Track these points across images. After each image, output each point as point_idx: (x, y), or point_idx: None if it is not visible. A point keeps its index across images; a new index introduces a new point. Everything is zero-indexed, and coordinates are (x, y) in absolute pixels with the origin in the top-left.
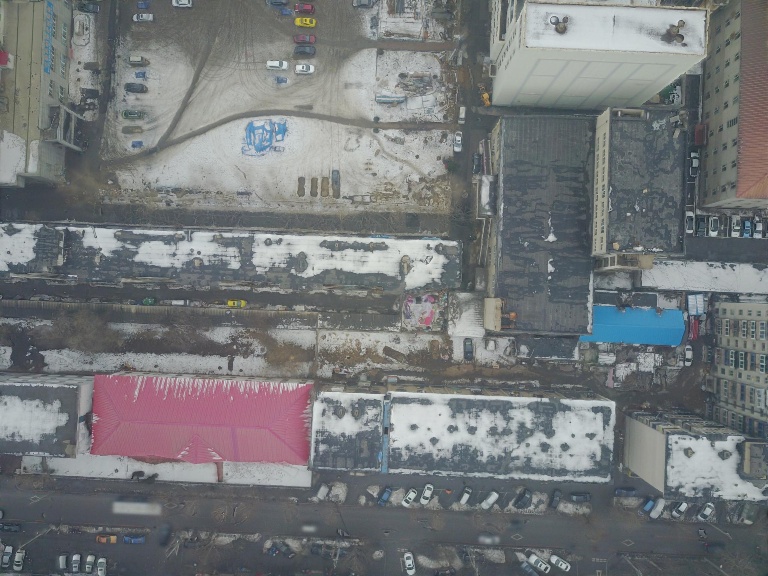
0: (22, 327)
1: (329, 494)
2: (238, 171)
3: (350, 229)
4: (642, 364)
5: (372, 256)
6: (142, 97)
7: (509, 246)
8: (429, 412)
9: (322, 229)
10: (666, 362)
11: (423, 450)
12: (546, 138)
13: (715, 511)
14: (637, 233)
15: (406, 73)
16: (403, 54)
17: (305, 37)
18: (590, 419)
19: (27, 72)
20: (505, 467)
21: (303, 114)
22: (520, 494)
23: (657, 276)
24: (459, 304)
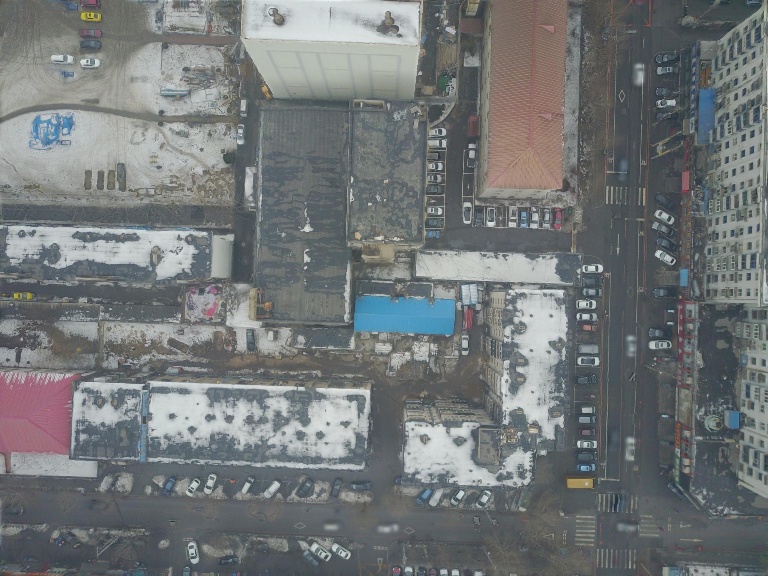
0: None
1: (115, 484)
2: (26, 165)
3: (136, 222)
4: (417, 353)
5: (123, 247)
6: None
7: (267, 237)
8: (187, 401)
9: (109, 222)
10: (445, 351)
11: (181, 439)
12: (302, 130)
13: (494, 499)
14: (378, 223)
15: (189, 67)
16: (188, 48)
17: (90, 31)
18: (345, 407)
19: None
20: (262, 455)
21: (90, 108)
22: (302, 483)
23: (431, 266)
24: (237, 295)
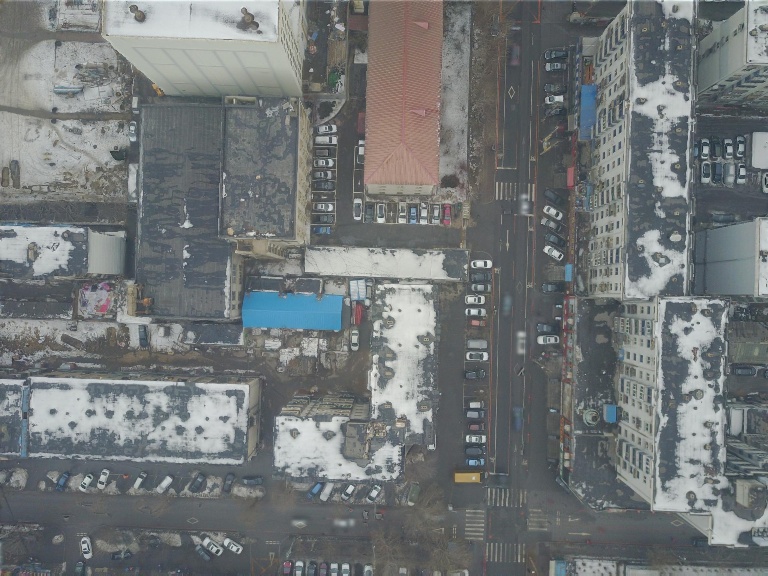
0: None
1: (10, 480)
2: None
3: (30, 218)
4: (306, 349)
5: (0, 243)
6: None
7: (148, 233)
8: (68, 397)
9: (3, 219)
10: (335, 347)
11: (62, 434)
12: (182, 126)
13: (384, 493)
14: (251, 218)
15: (82, 64)
16: (81, 45)
17: None
18: (224, 402)
19: None
20: (141, 450)
21: None
22: (195, 478)
23: (319, 262)
24: None
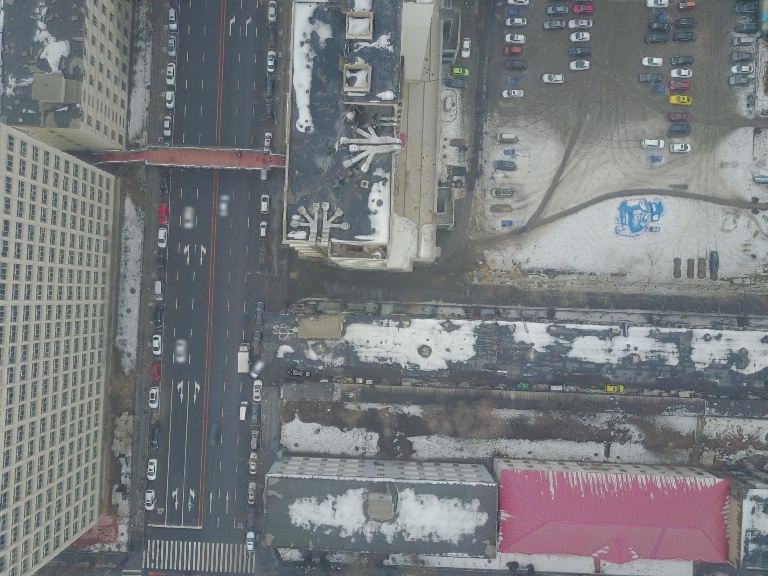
0: (389, 412)
1: None
2: (612, 252)
3: (728, 312)
4: None
5: None
6: (511, 175)
7: None
8: None
9: (699, 311)
10: None
11: None
12: None
13: None
14: None
15: None
16: None
17: (683, 116)
18: None
19: (418, 153)
20: None
21: (678, 194)
22: None
23: None
24: None
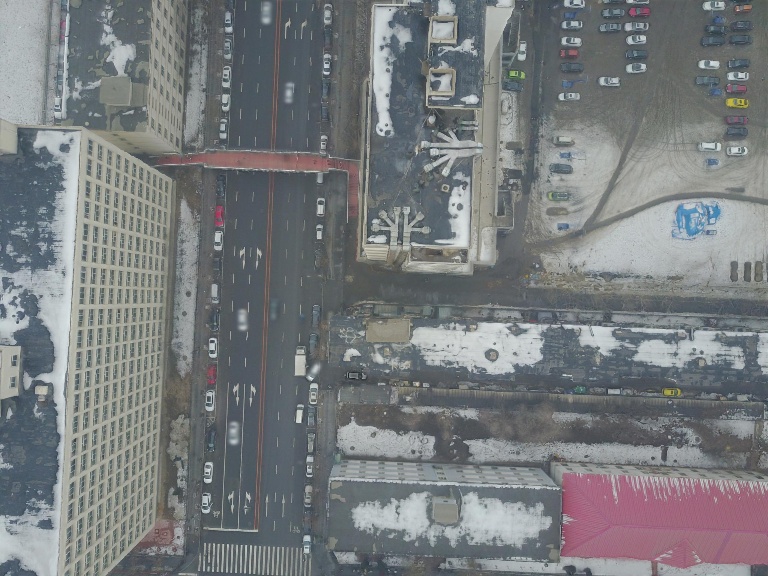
0: (445, 415)
1: None
2: (668, 255)
3: None
4: None
5: None
6: (567, 178)
7: None
8: None
9: (756, 315)
10: None
11: None
12: None
13: None
14: None
15: None
16: None
17: (740, 119)
18: None
19: None
20: None
21: (735, 197)
22: None
23: None
24: None
